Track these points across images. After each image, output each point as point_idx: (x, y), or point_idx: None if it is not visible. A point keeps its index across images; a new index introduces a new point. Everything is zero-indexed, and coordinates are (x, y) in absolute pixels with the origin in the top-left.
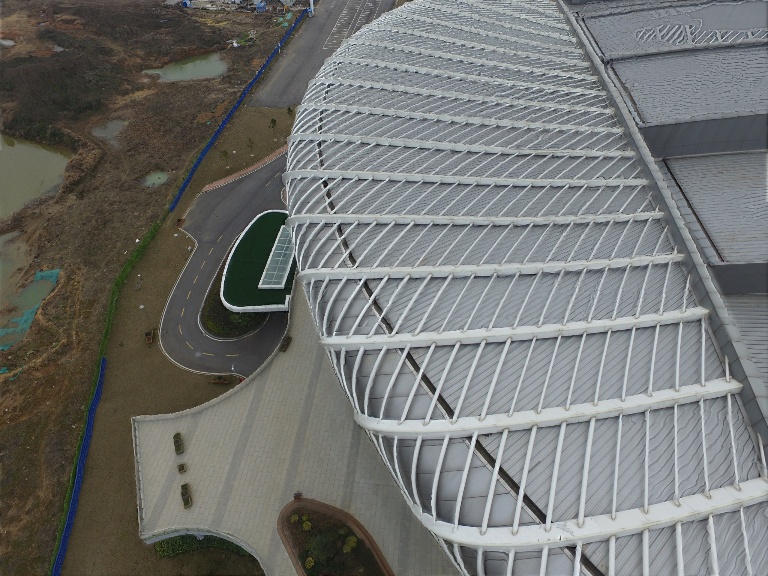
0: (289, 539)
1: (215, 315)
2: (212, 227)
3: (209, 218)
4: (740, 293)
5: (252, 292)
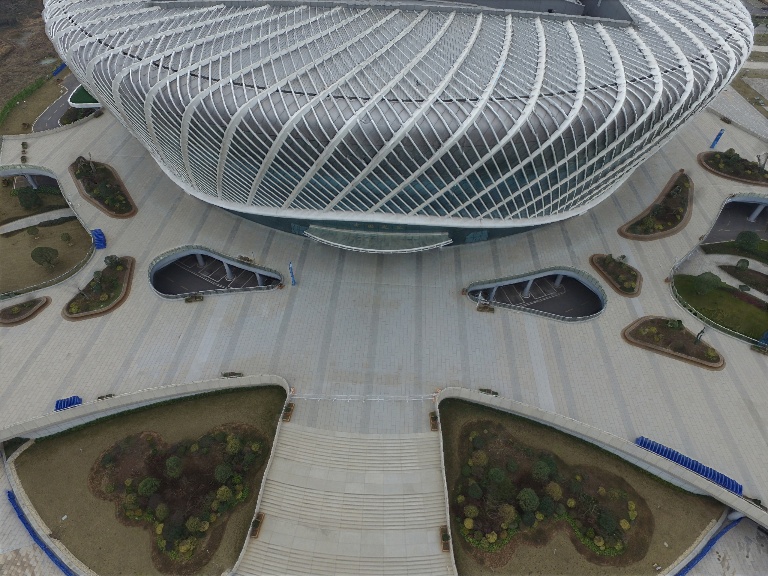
0: (72, 169)
1: (68, 117)
2: None
3: None
4: None
5: (88, 99)
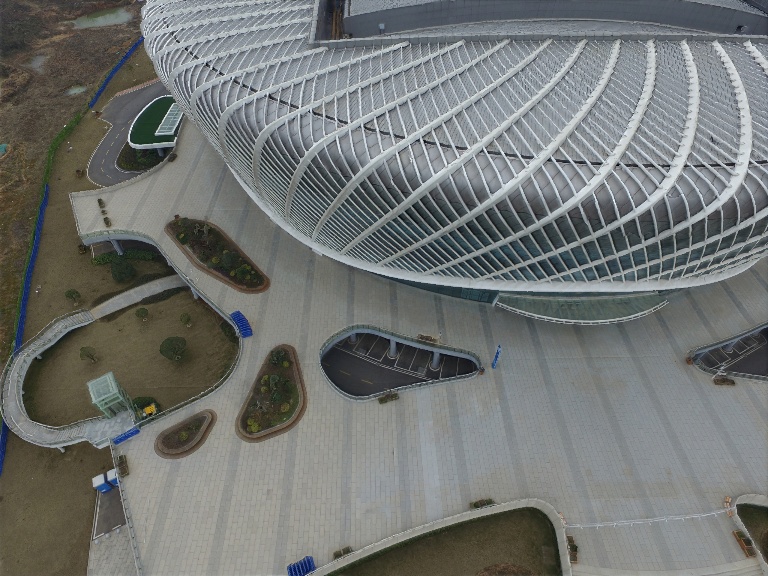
0: (171, 232)
1: (127, 159)
2: (123, 116)
3: (121, 111)
4: (365, 36)
5: (151, 138)
